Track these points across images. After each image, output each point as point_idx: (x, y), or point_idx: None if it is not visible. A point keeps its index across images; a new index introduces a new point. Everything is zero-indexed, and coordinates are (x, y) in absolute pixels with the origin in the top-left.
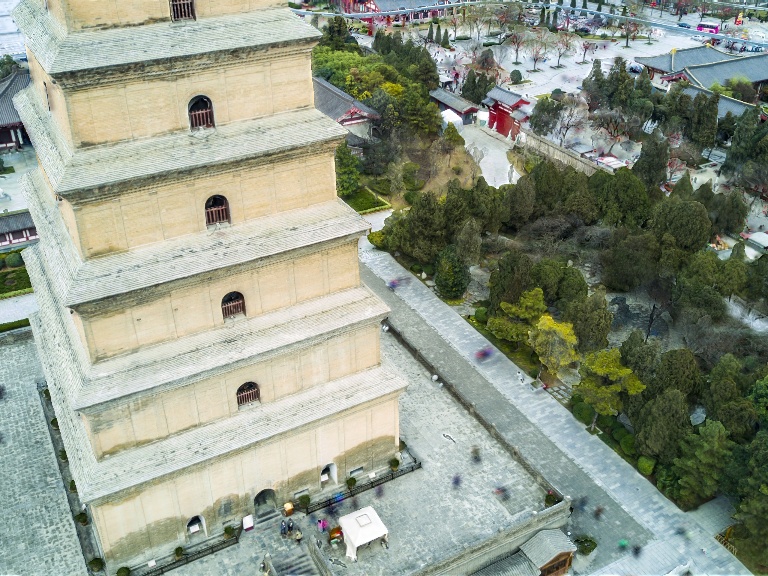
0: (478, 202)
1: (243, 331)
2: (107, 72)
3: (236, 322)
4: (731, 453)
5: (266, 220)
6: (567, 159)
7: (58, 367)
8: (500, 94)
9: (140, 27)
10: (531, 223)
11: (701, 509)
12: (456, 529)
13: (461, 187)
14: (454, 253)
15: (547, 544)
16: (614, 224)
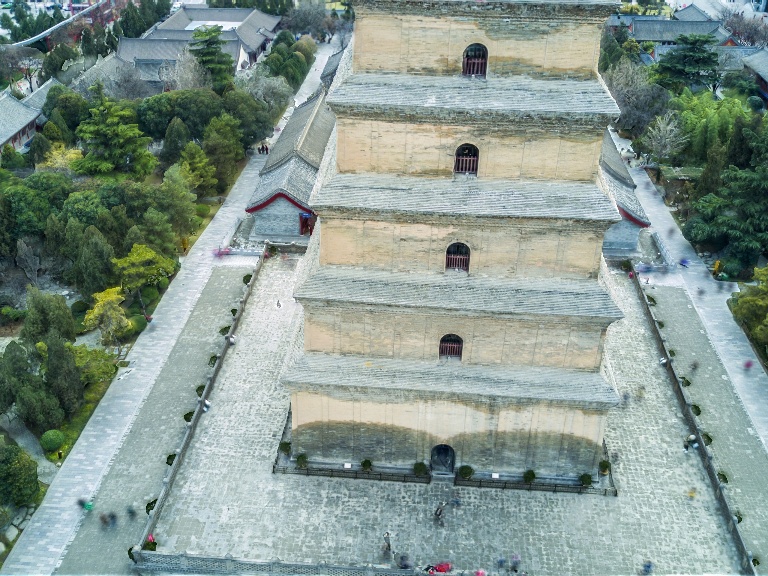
0: None
1: None
2: None
3: None
4: None
5: None
6: None
7: None
8: None
9: None
10: None
11: None
12: None
13: None
14: None
15: None
16: None
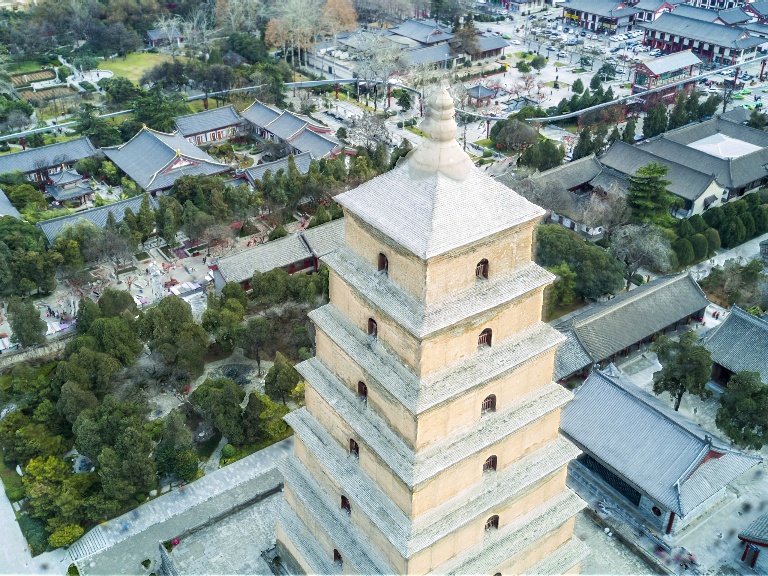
0: (132, 409)
1: None
2: None
3: None
4: None
5: None
6: None
7: None
8: None
9: None
10: None
11: None
12: None
13: None
14: (176, 445)
15: None
16: None
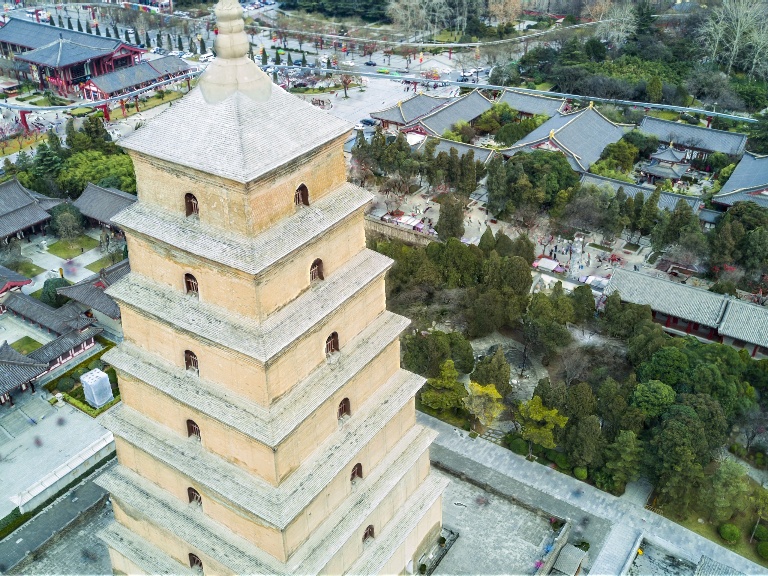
0: None
1: (364, 490)
2: (291, 343)
3: (358, 486)
4: (643, 449)
5: (367, 402)
6: (374, 225)
7: (242, 575)
8: None
9: (297, 300)
10: (394, 298)
11: (626, 491)
12: (511, 572)
13: None
14: None
15: (570, 558)
16: (456, 283)
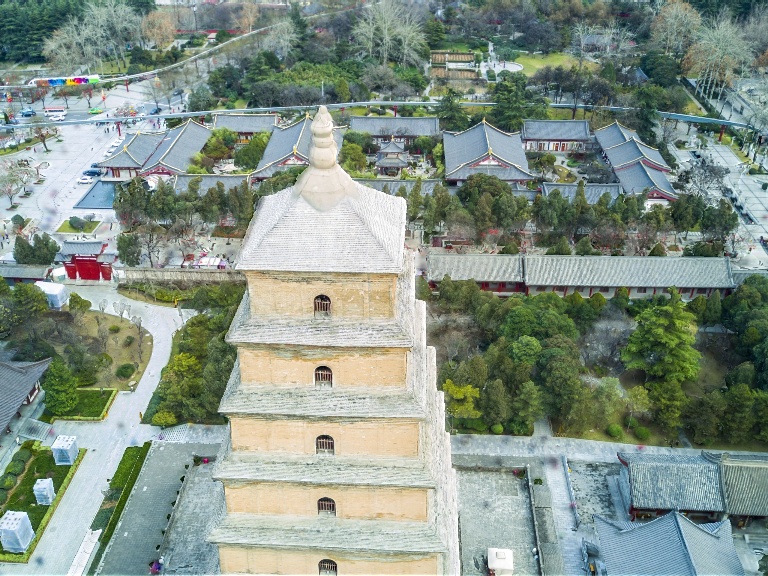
0: None
1: None
2: None
3: None
4: None
5: None
6: (180, 275)
7: None
8: (77, 248)
9: None
10: None
11: (534, 429)
12: (514, 524)
13: (137, 341)
14: None
15: (543, 494)
16: None
